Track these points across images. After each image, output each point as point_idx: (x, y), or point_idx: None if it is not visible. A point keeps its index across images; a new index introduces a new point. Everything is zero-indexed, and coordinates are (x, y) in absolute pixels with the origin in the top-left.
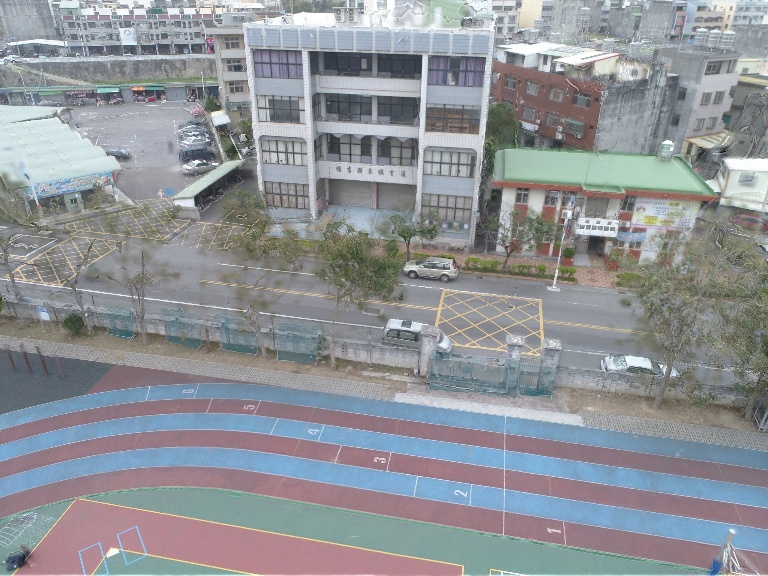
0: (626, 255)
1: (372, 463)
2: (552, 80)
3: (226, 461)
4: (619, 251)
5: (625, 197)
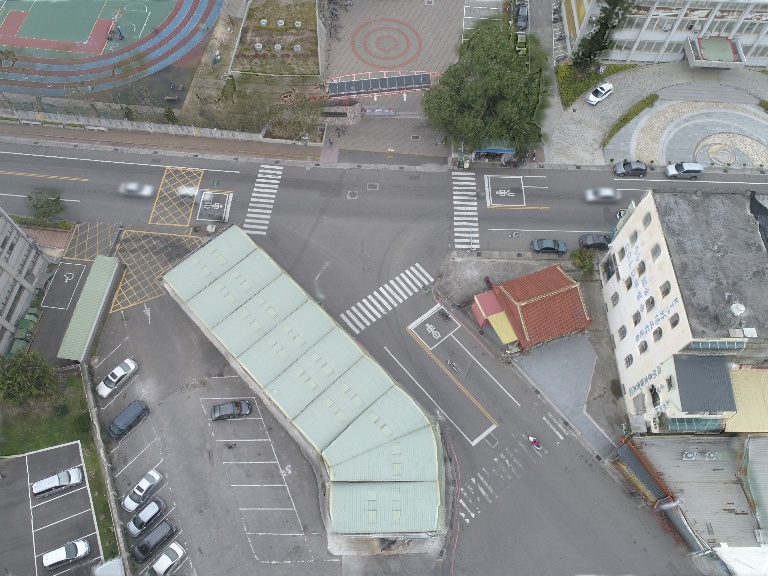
0: None
1: (8, 68)
2: None
3: (57, 67)
4: None
5: None
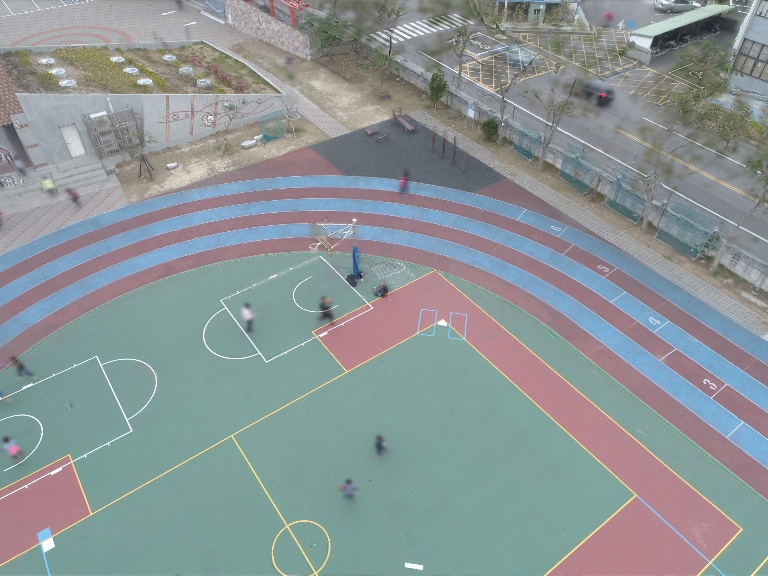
0: None
1: (699, 382)
2: None
3: (559, 304)
4: None
5: None
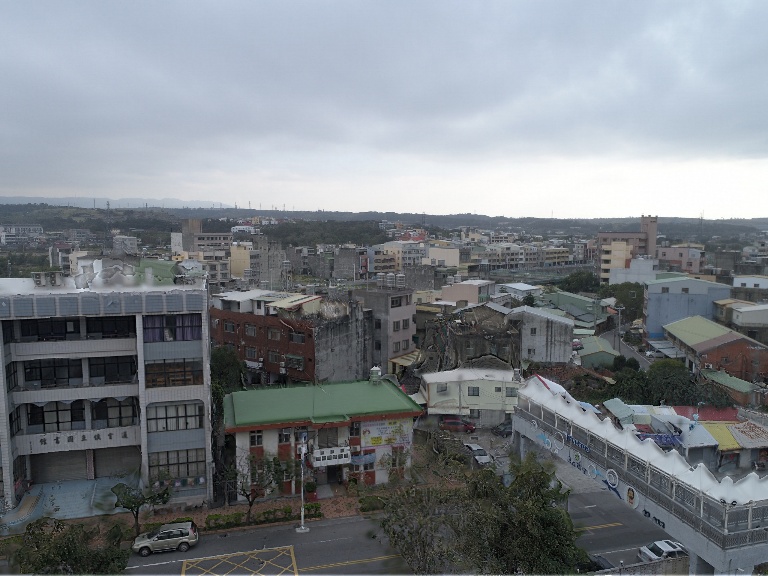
0: (363, 478)
1: None
2: (268, 322)
3: None
4: (356, 475)
5: (351, 424)
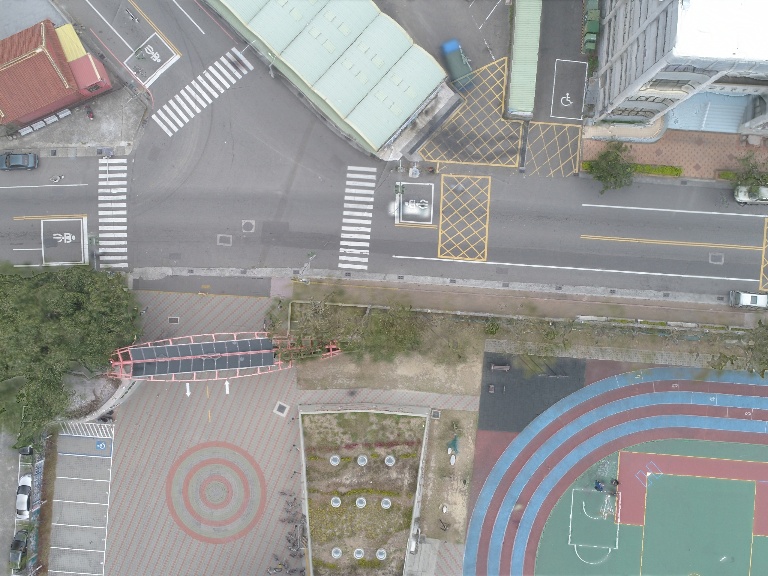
0: None
1: (745, 416)
2: None
3: (676, 423)
4: None
5: None
